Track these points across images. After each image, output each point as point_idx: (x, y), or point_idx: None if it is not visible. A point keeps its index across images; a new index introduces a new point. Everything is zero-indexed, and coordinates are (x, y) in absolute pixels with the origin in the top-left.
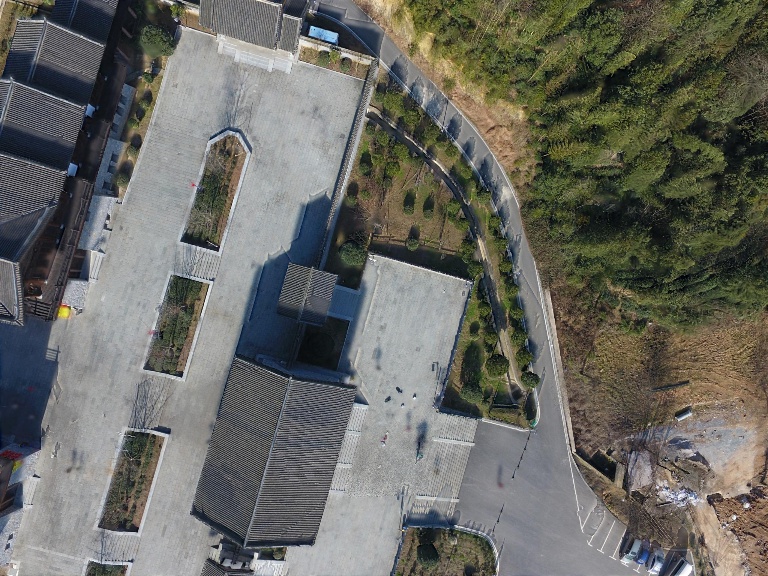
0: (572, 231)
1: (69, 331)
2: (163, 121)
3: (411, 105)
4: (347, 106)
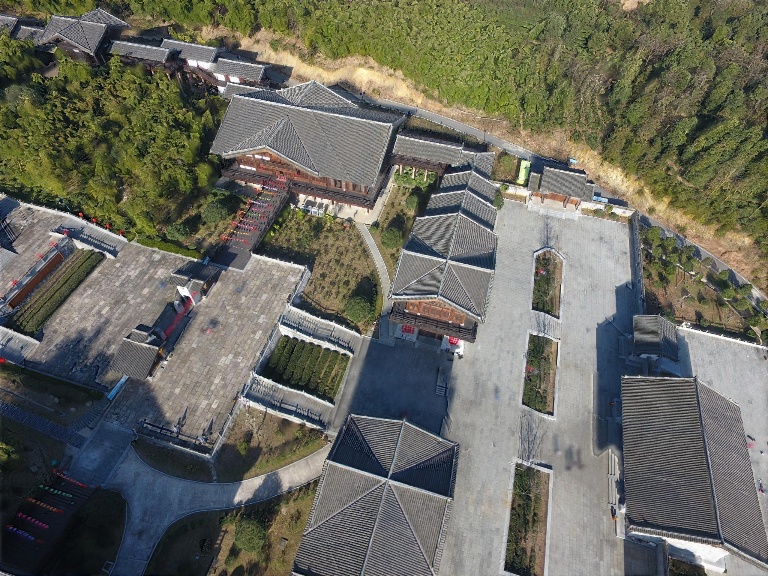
0: None
1: (454, 371)
2: (499, 243)
3: (660, 240)
4: (622, 237)
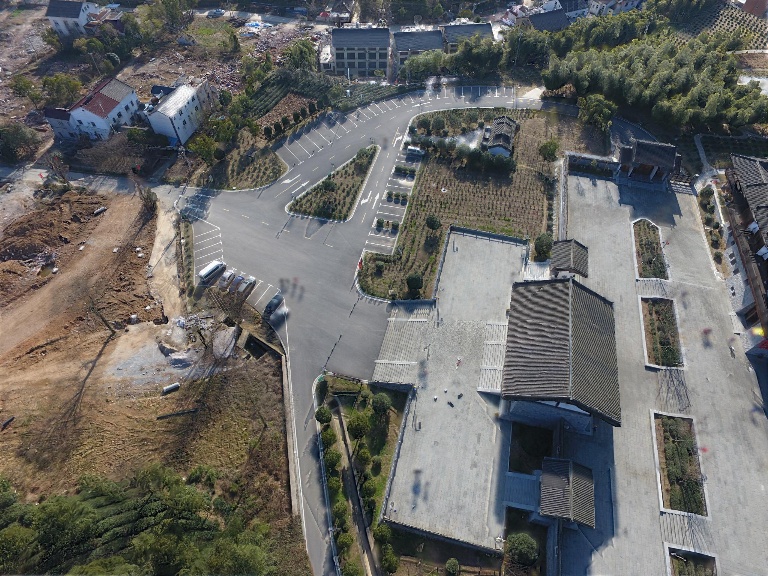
0: None
1: None
2: None
3: None
4: None
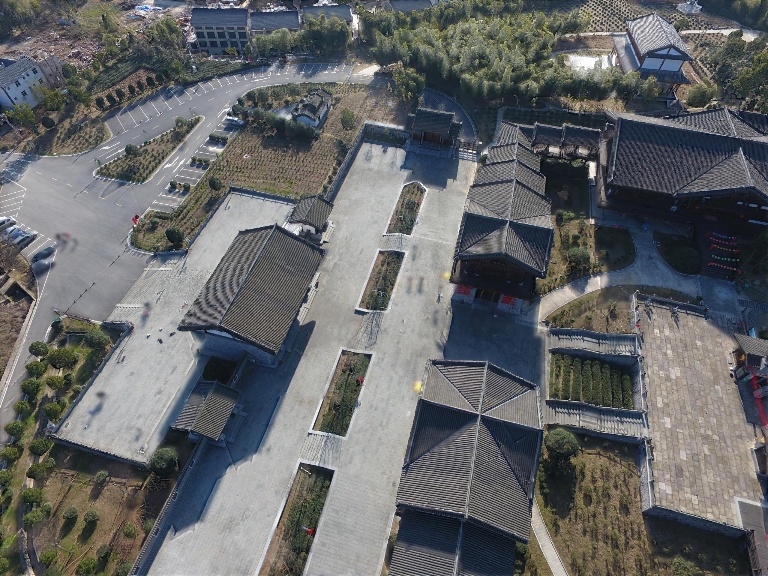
0: None
1: None
2: None
3: None
4: None
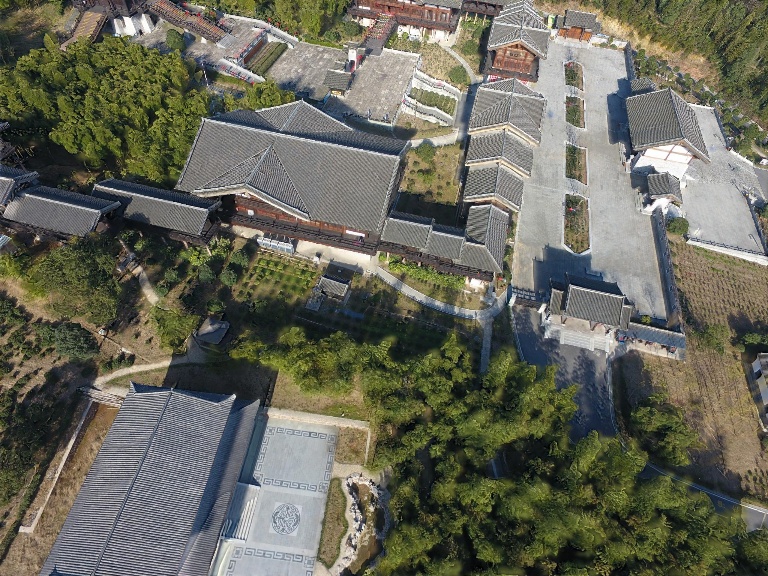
0: (752, 94)
1: None
2: None
3: None
4: (620, 57)
